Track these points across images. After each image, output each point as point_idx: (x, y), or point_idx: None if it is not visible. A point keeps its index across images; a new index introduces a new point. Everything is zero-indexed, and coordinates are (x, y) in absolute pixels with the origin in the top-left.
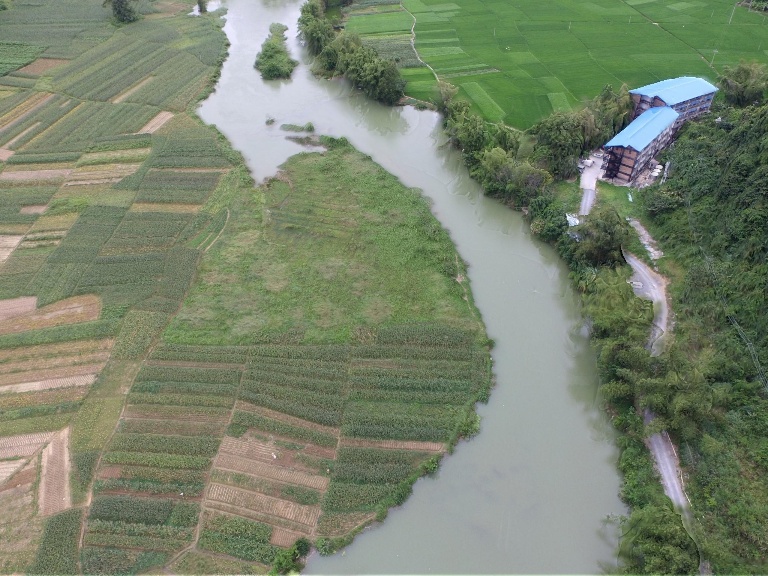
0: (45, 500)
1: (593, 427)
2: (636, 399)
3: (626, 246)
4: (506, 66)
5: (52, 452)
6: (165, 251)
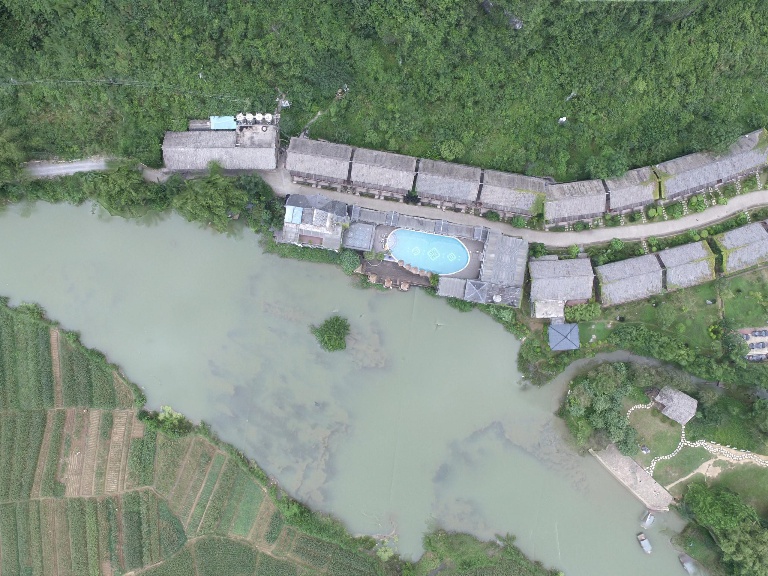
0: None
1: (18, 215)
2: None
3: None
4: None
5: None
6: None
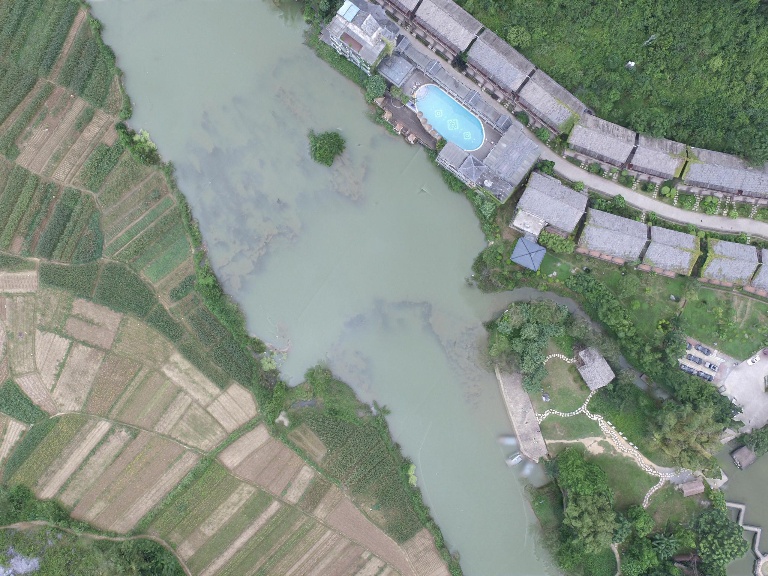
0: (25, 288)
1: None
2: None
3: None
4: None
5: None
6: None
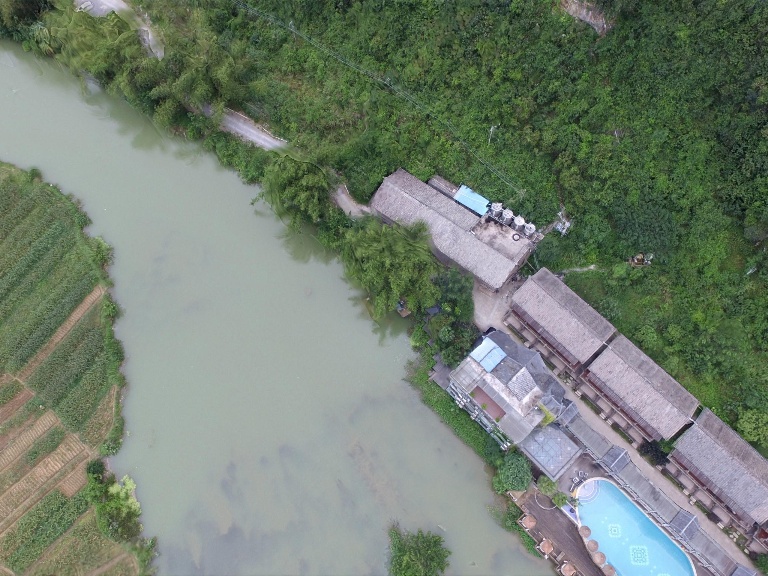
0: None
1: (181, 156)
2: (185, 105)
3: None
4: None
5: None
6: None
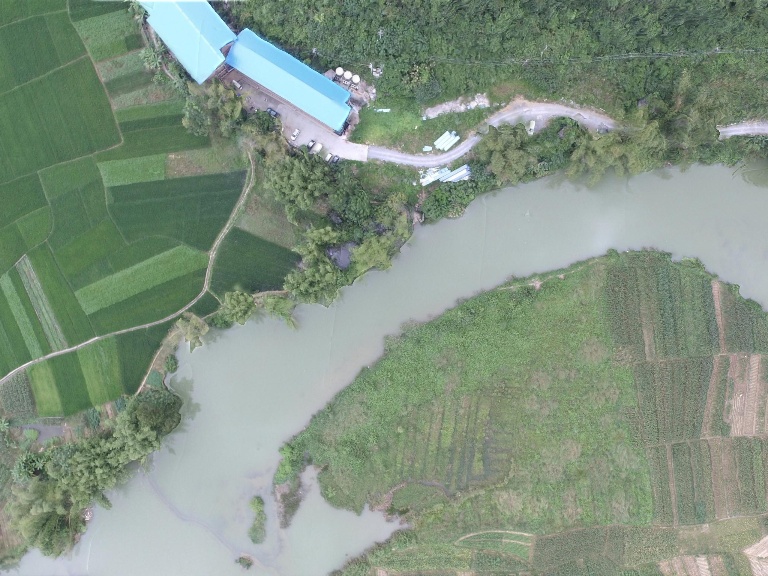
0: None
1: (659, 177)
2: (677, 147)
3: (471, 127)
4: (4, 247)
5: (765, 551)
6: (542, 575)
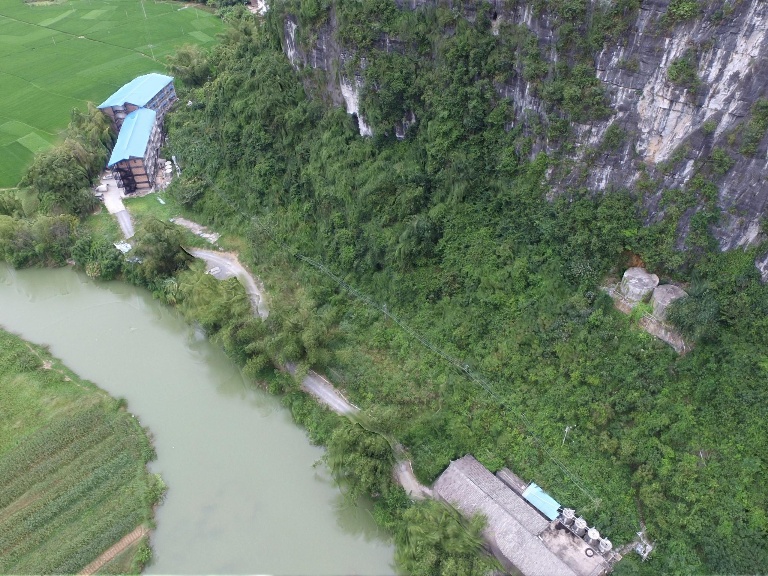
0: None
1: (258, 407)
2: (274, 362)
3: (185, 244)
4: None
5: None
6: None
